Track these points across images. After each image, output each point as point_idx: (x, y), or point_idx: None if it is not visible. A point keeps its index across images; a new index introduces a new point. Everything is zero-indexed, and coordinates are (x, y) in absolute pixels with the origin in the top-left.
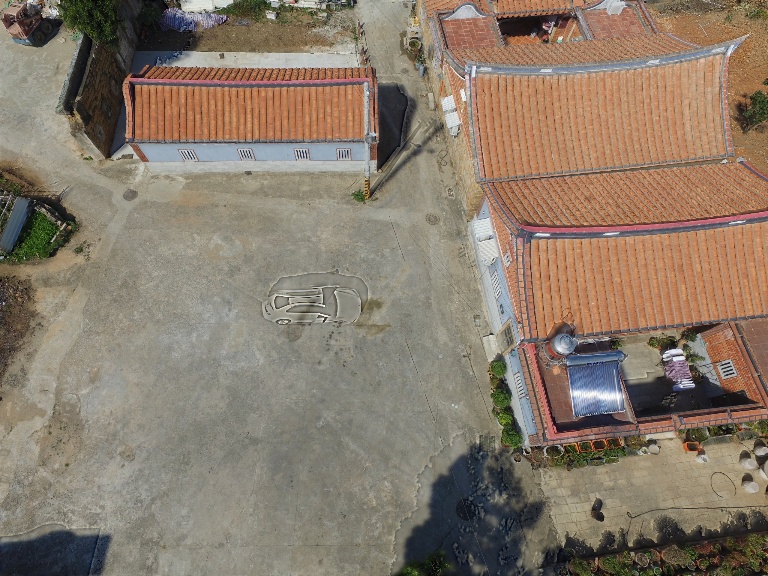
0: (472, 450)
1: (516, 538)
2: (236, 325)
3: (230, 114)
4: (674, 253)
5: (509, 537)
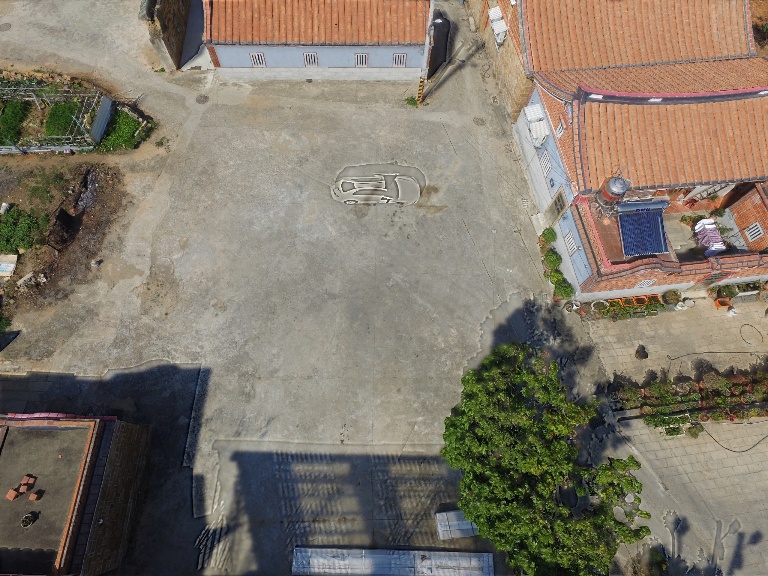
0: (527, 305)
1: (571, 372)
2: (308, 205)
3: (298, 19)
4: (709, 120)
5: (564, 372)
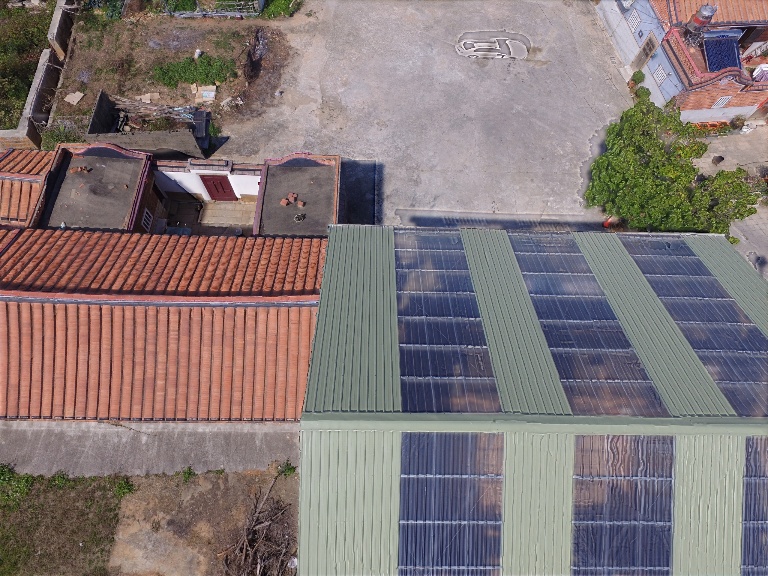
0: None
1: None
2: (439, 57)
3: None
4: None
5: None
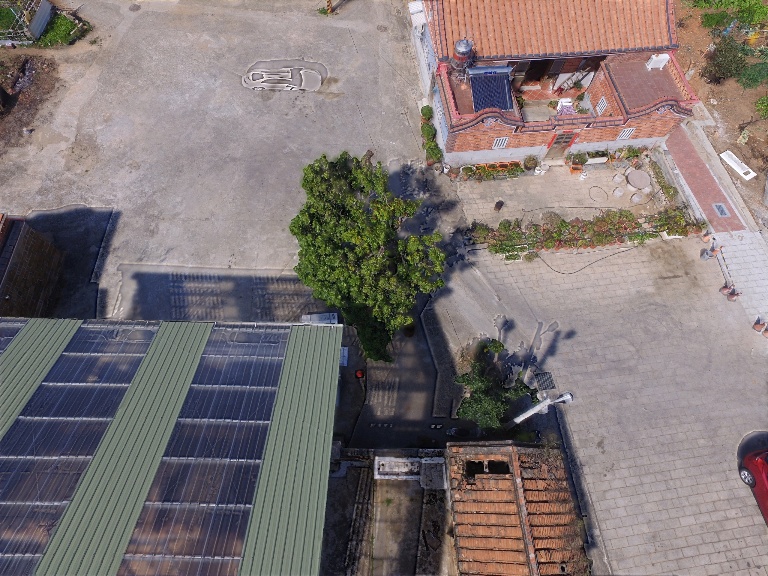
0: (404, 168)
1: (434, 218)
2: (221, 90)
3: None
4: (555, 3)
5: (429, 217)
